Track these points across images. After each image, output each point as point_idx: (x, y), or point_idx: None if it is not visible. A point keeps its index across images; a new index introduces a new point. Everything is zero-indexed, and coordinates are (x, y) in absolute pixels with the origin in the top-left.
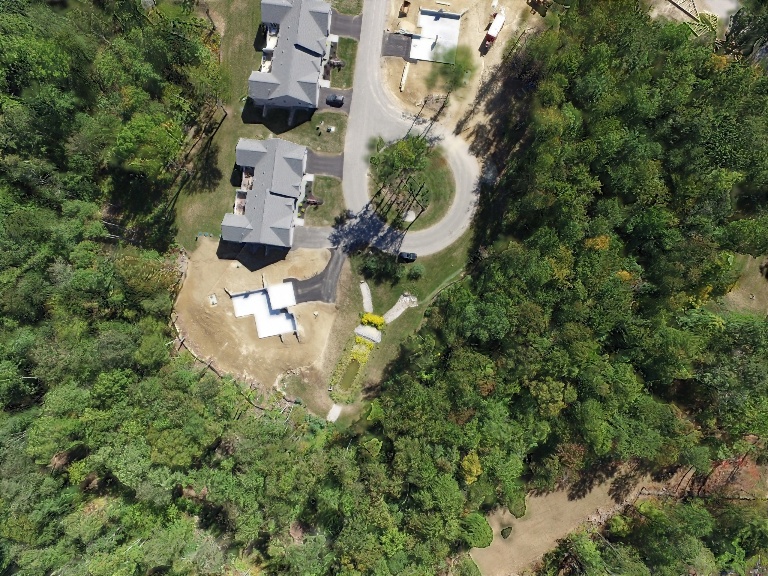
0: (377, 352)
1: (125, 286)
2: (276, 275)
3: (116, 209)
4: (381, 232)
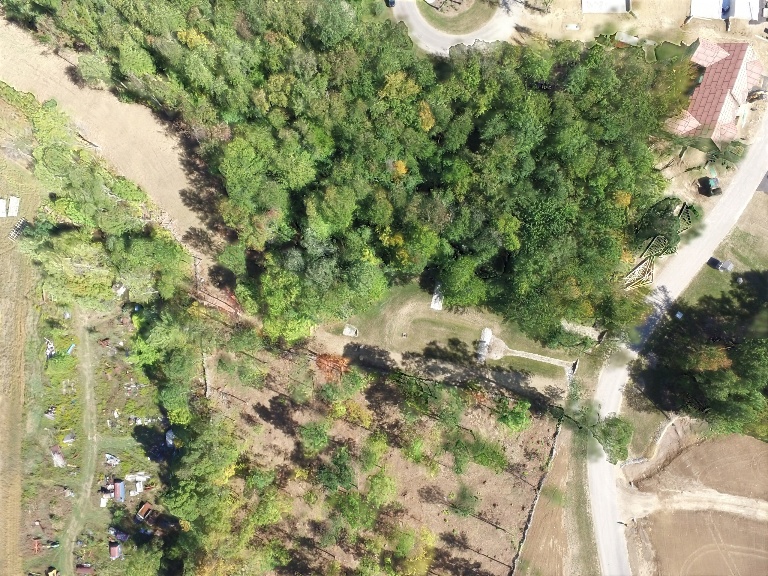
0: None
1: None
2: None
3: None
4: None
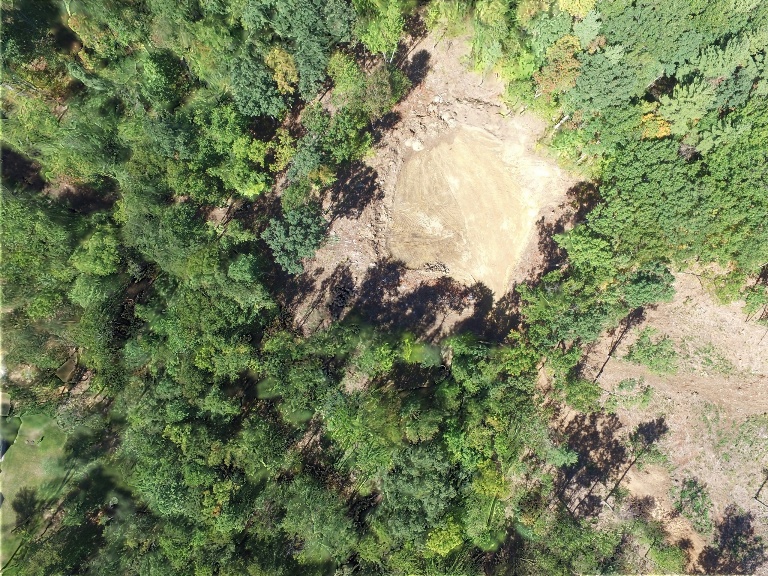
0: None
1: None
2: None
3: None
4: None
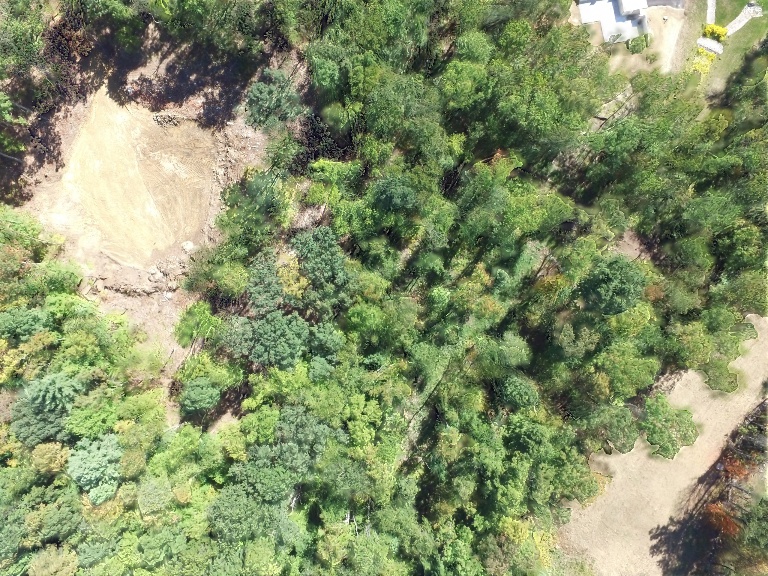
0: (720, 62)
1: None
2: None
3: None
4: None
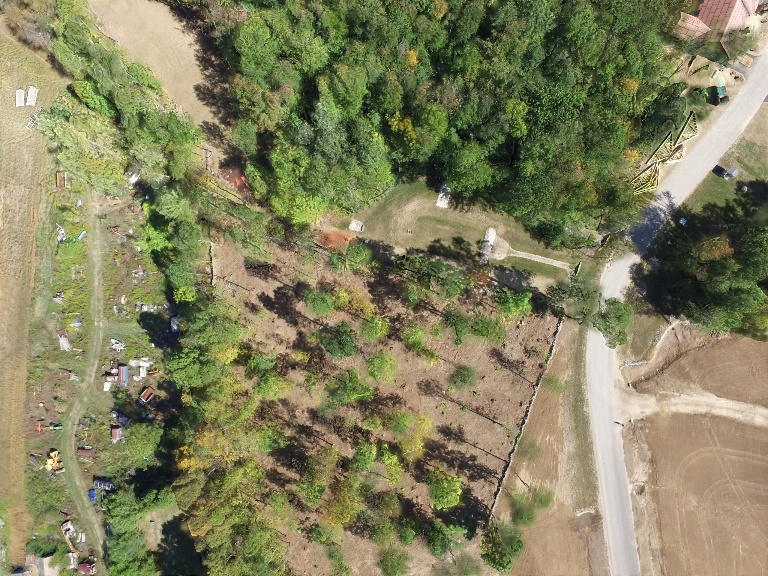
0: None
1: None
2: None
3: None
4: None
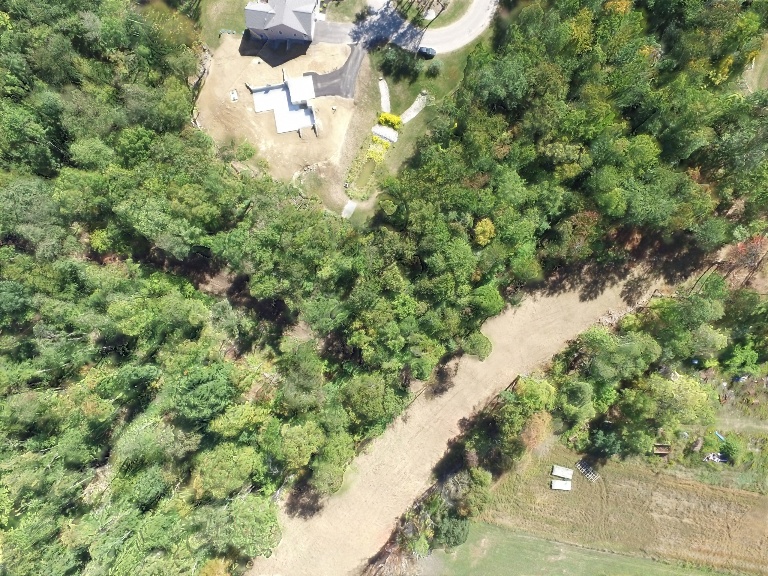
0: (393, 151)
1: (151, 43)
2: (296, 69)
3: (143, 8)
4: (401, 29)
